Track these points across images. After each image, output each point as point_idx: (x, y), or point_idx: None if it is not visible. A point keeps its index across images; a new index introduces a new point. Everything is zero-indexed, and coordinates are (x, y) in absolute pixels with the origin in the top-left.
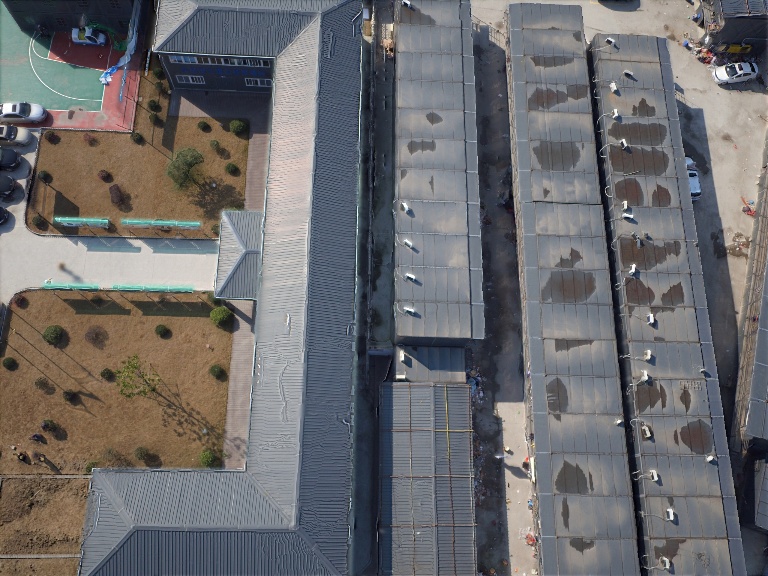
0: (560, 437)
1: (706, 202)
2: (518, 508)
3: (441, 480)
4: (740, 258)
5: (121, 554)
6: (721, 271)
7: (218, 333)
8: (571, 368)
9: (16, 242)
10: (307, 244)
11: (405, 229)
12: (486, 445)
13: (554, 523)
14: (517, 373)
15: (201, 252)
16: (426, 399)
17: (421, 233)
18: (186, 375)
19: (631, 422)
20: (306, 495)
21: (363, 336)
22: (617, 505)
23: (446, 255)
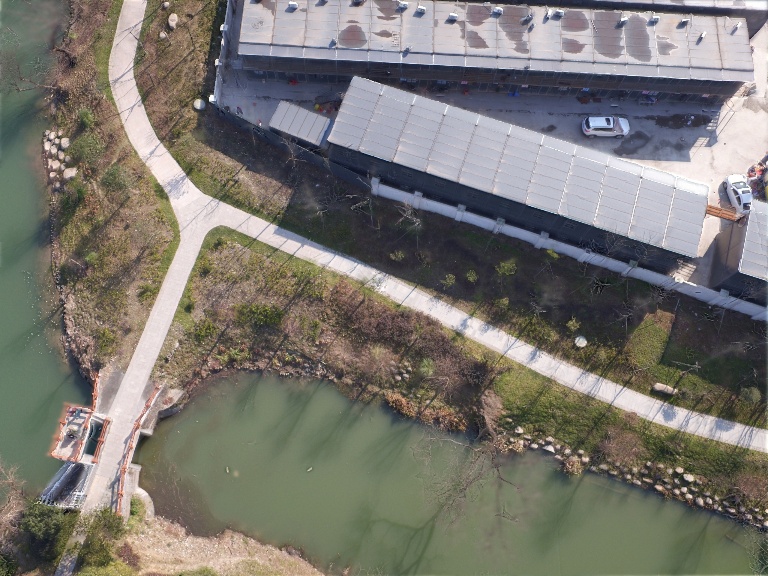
0: None
1: None
2: None
3: None
4: None
5: None
6: None
7: None
8: None
9: None
10: None
11: None
12: None
13: None
14: None
15: None
16: None
17: None
18: None
19: None
20: None
21: None
22: None
23: None
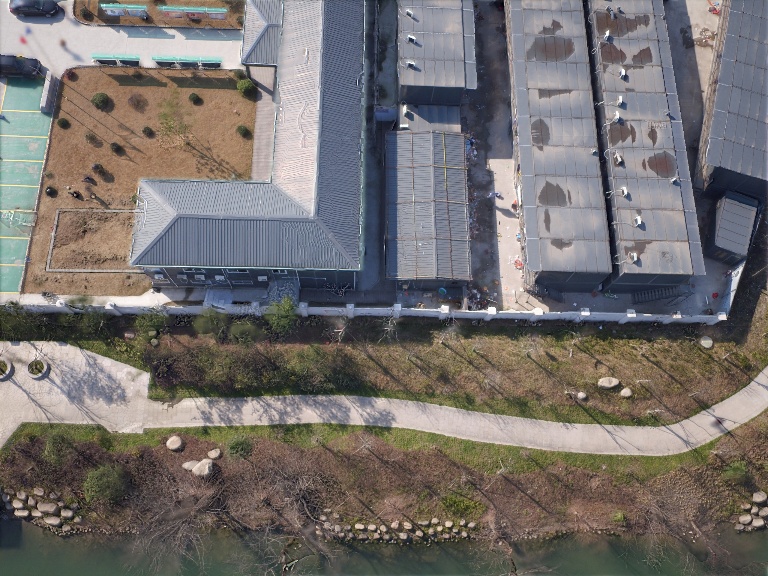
0: (543, 163)
1: (676, 4)
2: (508, 241)
3: (440, 204)
4: (706, 48)
5: (166, 240)
6: (689, 58)
7: (244, 102)
8: (552, 111)
9: (66, 30)
10: (321, 7)
11: (407, 3)
12: (479, 192)
13: (537, 228)
14: (507, 136)
15: (228, 39)
16: (426, 142)
17: (421, 7)
18: (216, 134)
19: (605, 154)
20: (323, 190)
21: (371, 106)
22: (592, 215)
23: (443, 24)
